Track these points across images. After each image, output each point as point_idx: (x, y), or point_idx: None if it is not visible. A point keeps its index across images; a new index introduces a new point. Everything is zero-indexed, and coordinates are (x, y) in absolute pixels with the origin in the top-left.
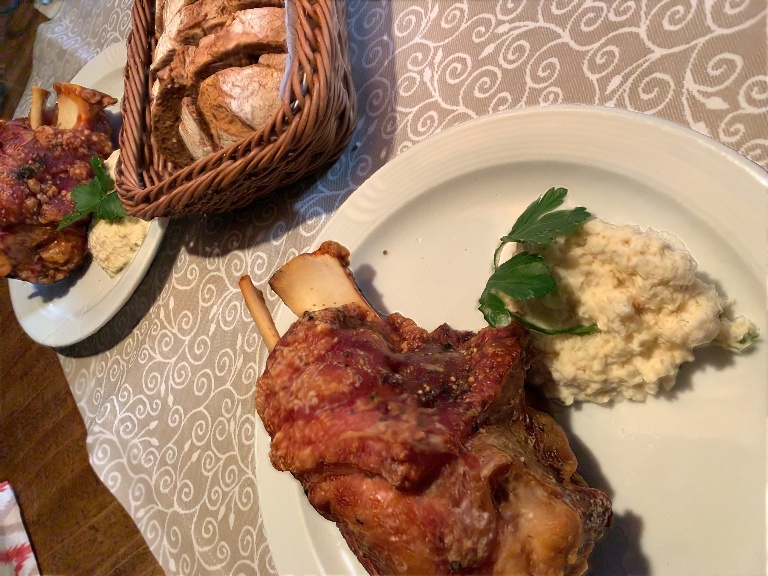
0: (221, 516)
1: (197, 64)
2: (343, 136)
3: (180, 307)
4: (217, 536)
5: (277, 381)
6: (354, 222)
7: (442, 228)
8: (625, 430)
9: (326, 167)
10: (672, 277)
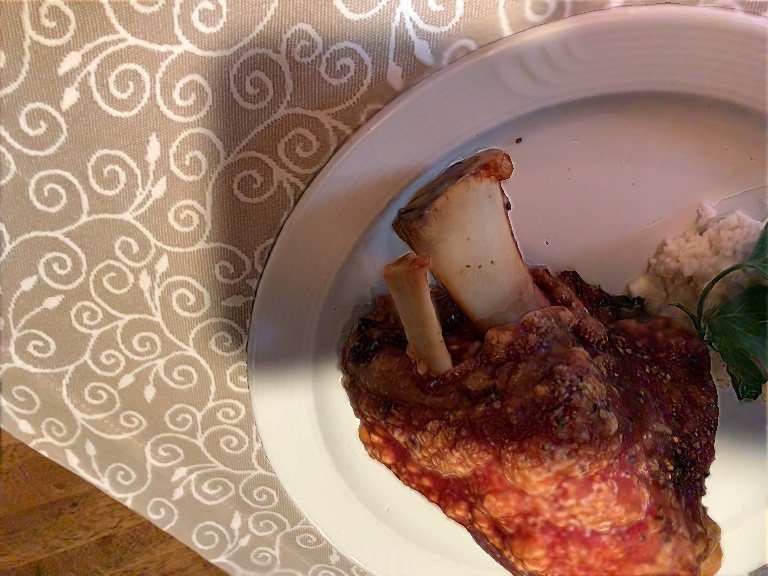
0: (125, 385)
1: None
2: None
3: None
4: (118, 404)
5: (538, 488)
6: (505, 88)
7: (616, 140)
8: None
9: None
10: None
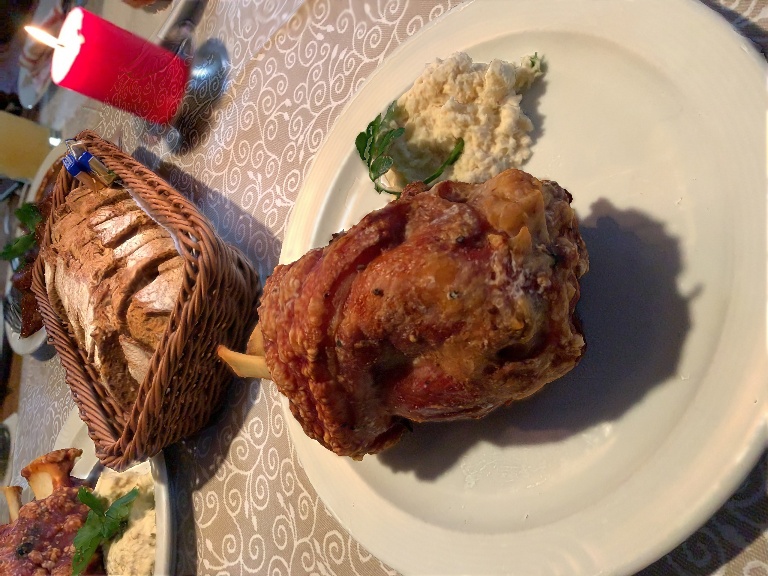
0: None
1: (116, 307)
2: (251, 278)
3: (218, 539)
4: None
5: (270, 321)
6: None
7: None
8: (540, 177)
9: (257, 316)
10: (456, 63)
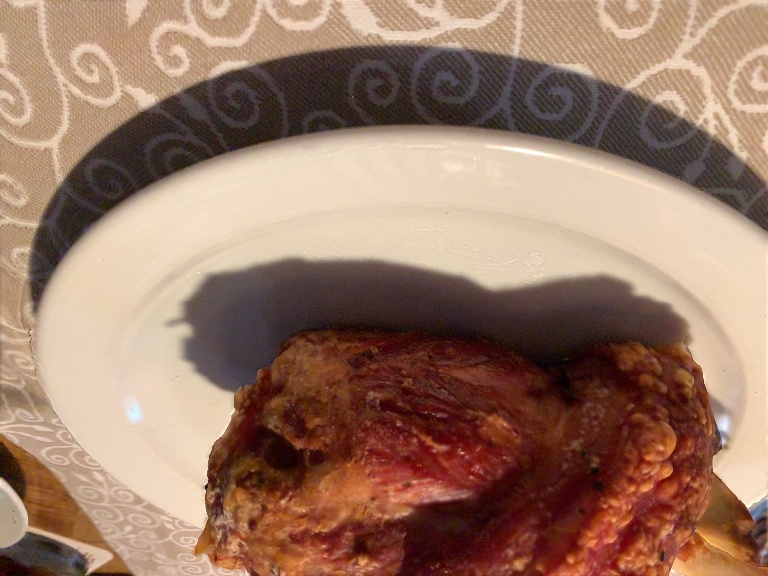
0: None
1: None
2: (757, 537)
3: None
4: None
5: None
6: None
7: None
8: None
9: None
10: None
